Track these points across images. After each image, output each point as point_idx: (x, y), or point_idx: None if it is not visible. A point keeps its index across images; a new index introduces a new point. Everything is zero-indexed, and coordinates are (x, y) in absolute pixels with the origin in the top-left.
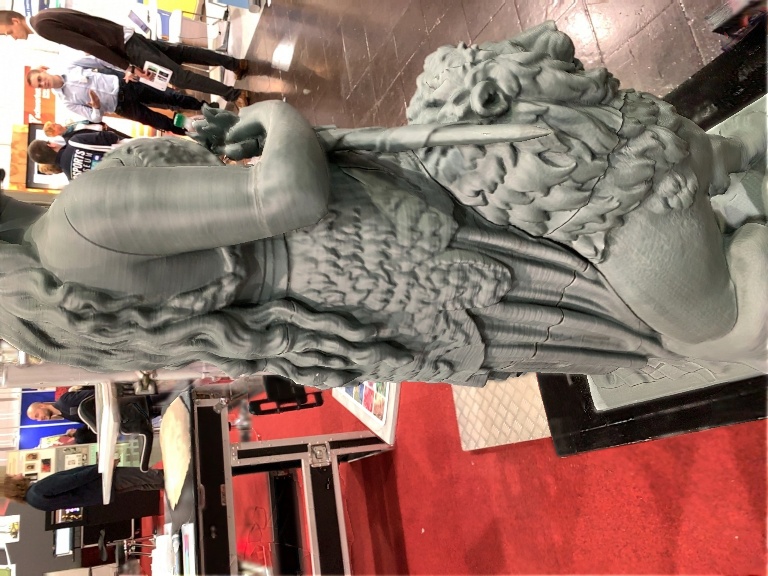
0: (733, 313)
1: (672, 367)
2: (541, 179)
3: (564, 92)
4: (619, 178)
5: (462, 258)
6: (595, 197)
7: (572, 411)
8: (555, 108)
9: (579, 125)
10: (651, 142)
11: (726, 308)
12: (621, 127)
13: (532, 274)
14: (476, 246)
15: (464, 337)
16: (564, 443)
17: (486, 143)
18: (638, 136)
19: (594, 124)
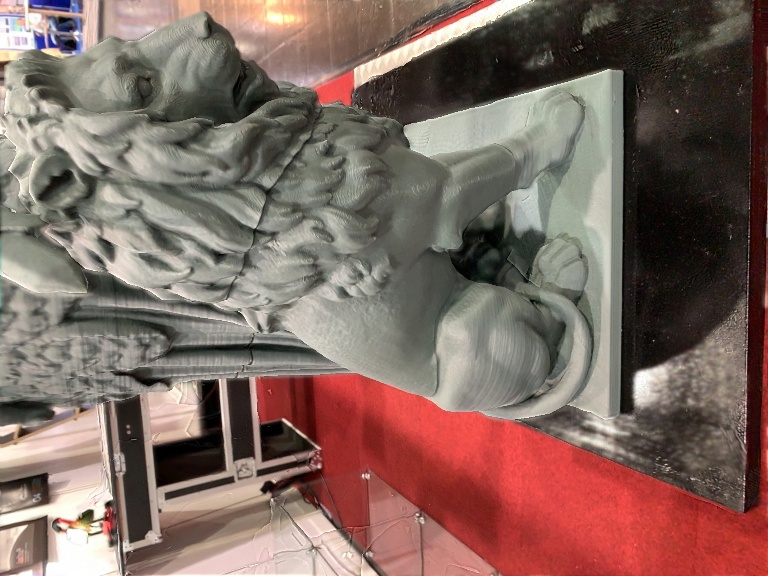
0: (432, 386)
1: None
2: (148, 281)
3: (168, 178)
4: (264, 277)
5: (83, 334)
6: (237, 292)
7: None
8: (151, 204)
9: (188, 227)
10: (310, 236)
11: (424, 381)
12: (258, 224)
13: (201, 329)
14: (112, 311)
15: (118, 390)
16: None
17: (69, 230)
18: (291, 228)
19: (208, 229)
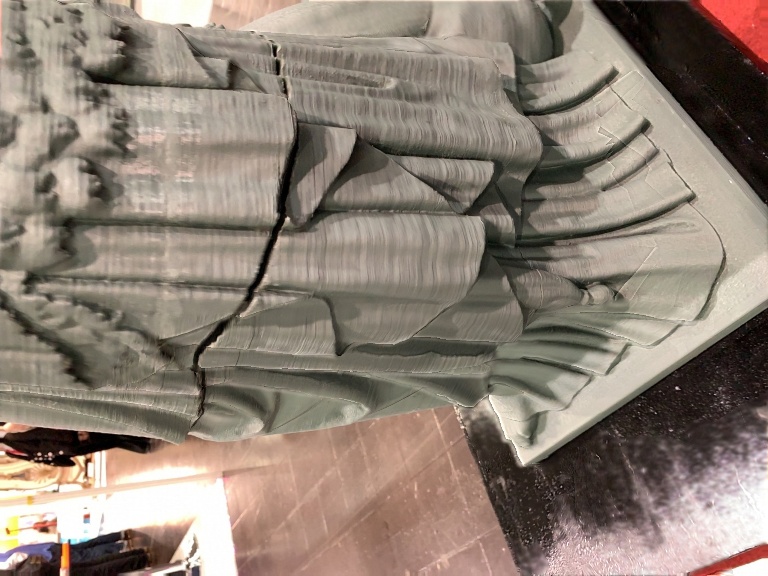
0: None
1: (608, 119)
2: None
3: None
4: None
5: None
6: None
7: None
8: None
9: None
10: None
11: None
12: None
13: None
14: None
15: None
16: None
17: None
18: None
19: None
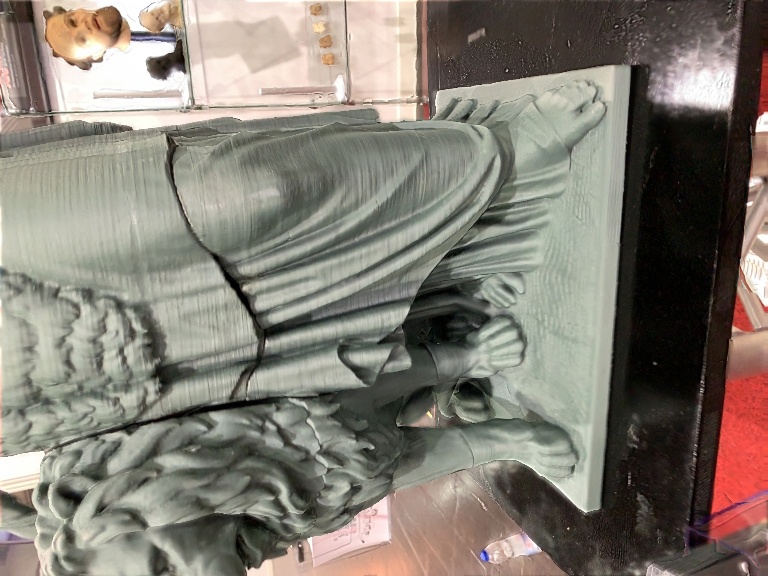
0: None
1: None
2: None
3: None
4: None
5: None
6: None
7: (451, 34)
8: None
9: None
10: None
11: None
12: None
13: None
14: None
15: None
16: (433, 10)
17: None
18: None
19: None
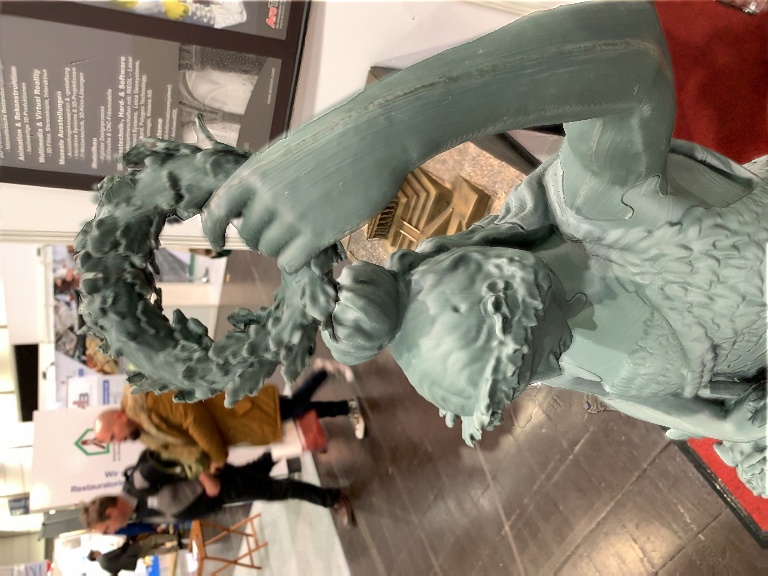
0: None
1: None
2: None
3: None
4: None
5: None
6: None
7: None
8: None
9: None
10: None
11: None
12: None
13: None
14: None
15: None
16: None
17: None
18: None
19: None
